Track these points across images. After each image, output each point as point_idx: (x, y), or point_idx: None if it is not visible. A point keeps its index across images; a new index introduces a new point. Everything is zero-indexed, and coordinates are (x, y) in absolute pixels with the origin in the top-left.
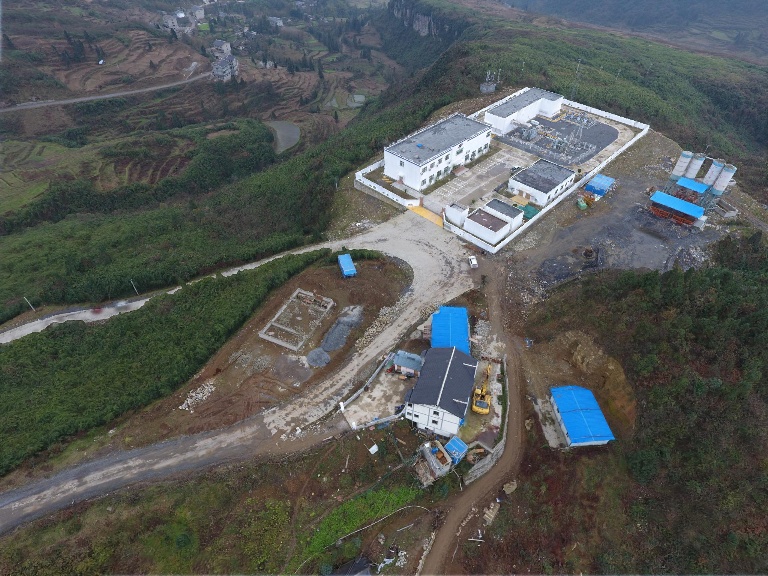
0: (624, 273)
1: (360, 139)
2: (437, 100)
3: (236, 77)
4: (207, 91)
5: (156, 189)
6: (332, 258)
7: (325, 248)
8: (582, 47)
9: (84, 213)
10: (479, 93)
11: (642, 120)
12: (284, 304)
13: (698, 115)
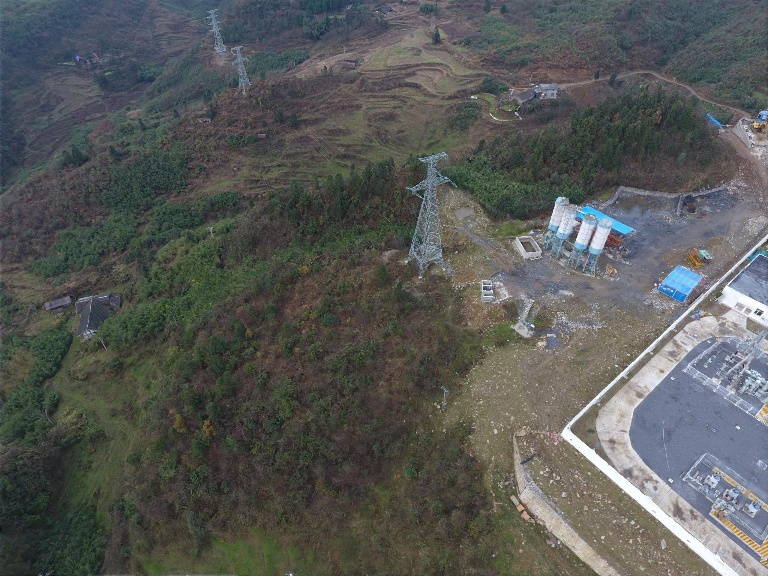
0: None
1: None
2: None
3: None
4: None
5: None
6: None
7: None
8: None
9: None
10: None
11: None
12: None
13: None
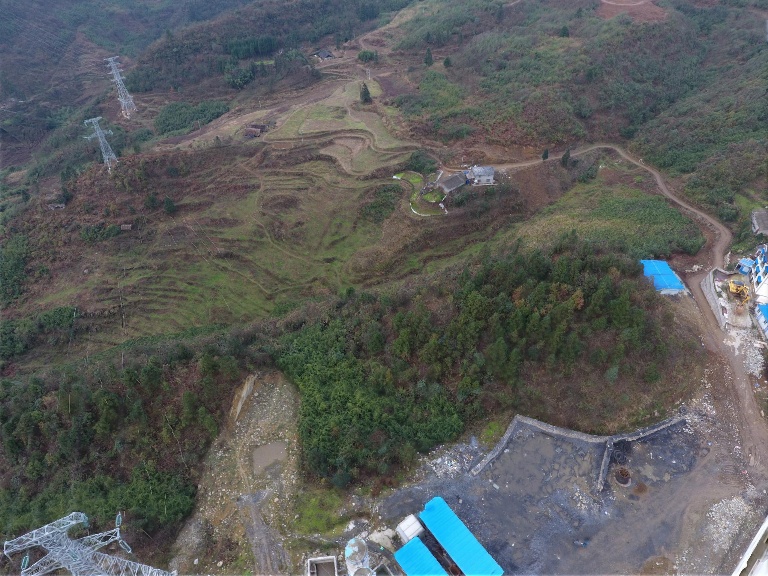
0: None
1: None
2: None
3: None
4: None
5: None
6: None
7: None
8: None
9: None
10: None
11: None
12: None
13: None
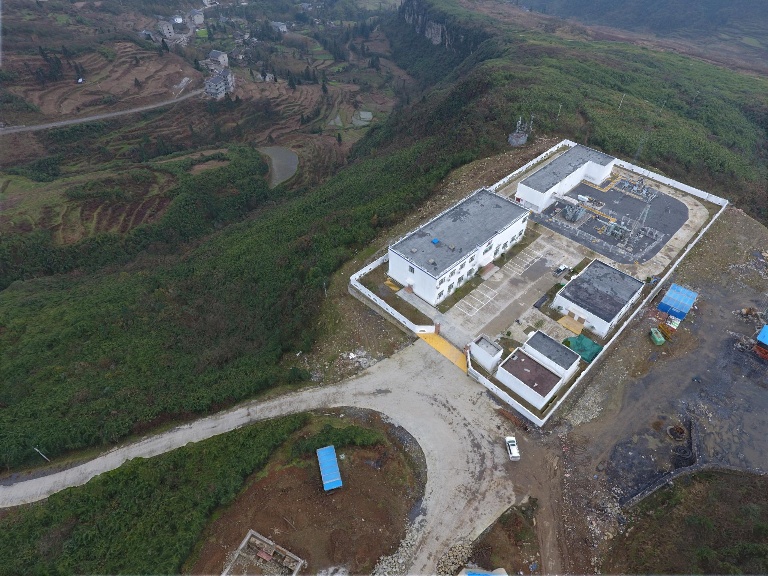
0: (754, 512)
1: (359, 213)
2: (456, 156)
3: (231, 94)
4: (198, 111)
5: (127, 240)
6: (309, 447)
7: (302, 414)
8: (618, 70)
9: (39, 273)
10: (507, 146)
11: (705, 178)
12: (226, 562)
13: (752, 151)
